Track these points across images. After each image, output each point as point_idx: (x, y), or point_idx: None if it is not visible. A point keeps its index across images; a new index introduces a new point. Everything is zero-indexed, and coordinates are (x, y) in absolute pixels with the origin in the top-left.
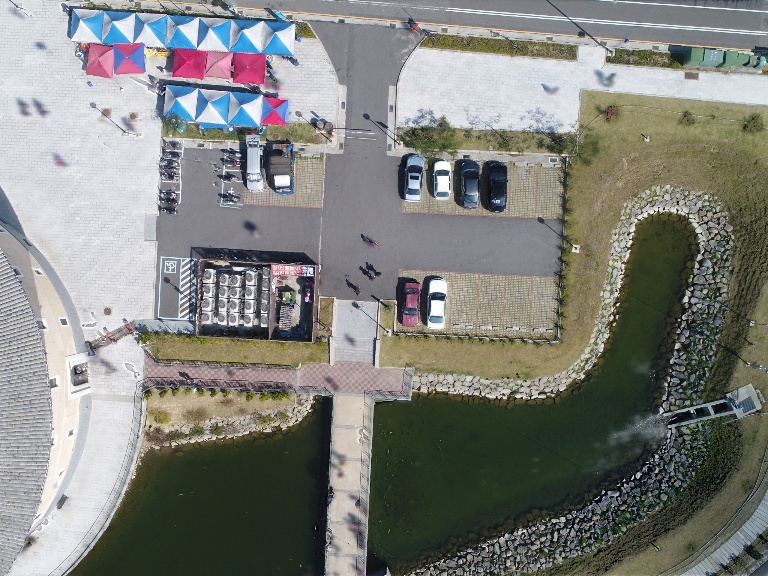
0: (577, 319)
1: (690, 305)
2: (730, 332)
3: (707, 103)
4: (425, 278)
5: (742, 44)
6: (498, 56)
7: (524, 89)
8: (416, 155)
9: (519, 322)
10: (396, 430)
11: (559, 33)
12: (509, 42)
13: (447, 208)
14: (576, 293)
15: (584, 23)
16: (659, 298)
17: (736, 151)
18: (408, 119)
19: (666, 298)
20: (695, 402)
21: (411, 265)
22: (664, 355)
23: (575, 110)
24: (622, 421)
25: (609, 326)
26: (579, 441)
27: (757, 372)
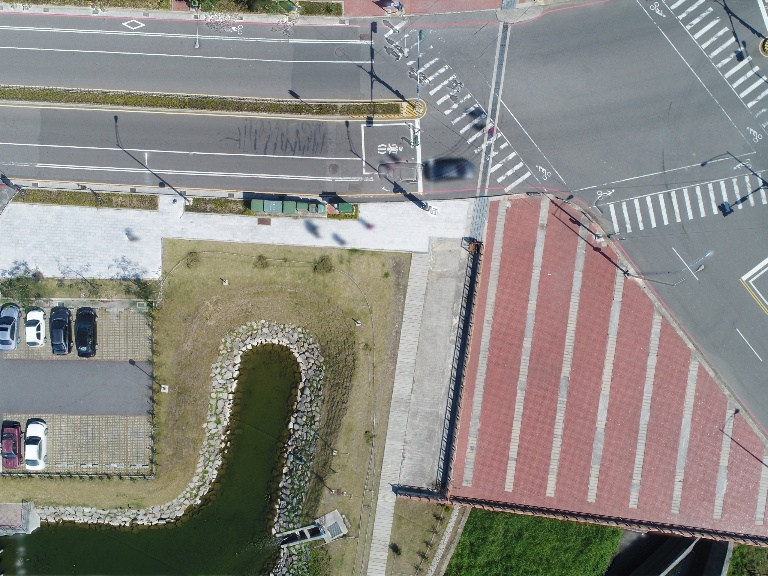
0: (174, 453)
1: (294, 431)
2: (320, 460)
3: (280, 247)
4: (28, 421)
5: (310, 190)
6: (85, 208)
7: (110, 239)
8: (11, 305)
9: (117, 459)
10: (32, 557)
11: (141, 184)
12: (94, 195)
13: (45, 354)
14: (169, 430)
15: (164, 174)
16: (271, 423)
17: (309, 291)
18: (4, 271)
19: (277, 423)
20: (295, 526)
21: (14, 409)
22: (275, 478)
23: (158, 257)
24: (243, 541)
25: (221, 453)
26: (204, 561)
27: (342, 498)
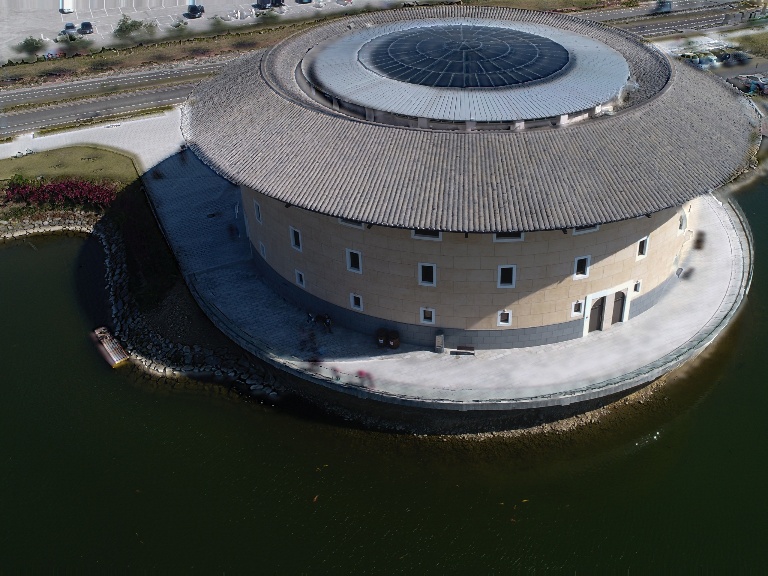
0: None
1: None
2: None
3: None
4: None
5: None
6: None
7: None
8: None
9: None
10: None
11: None
12: None
13: None
14: None
15: None
16: None
17: None
18: None
19: None
20: None
21: None
22: None
23: None
24: None
25: None
26: None
27: None
